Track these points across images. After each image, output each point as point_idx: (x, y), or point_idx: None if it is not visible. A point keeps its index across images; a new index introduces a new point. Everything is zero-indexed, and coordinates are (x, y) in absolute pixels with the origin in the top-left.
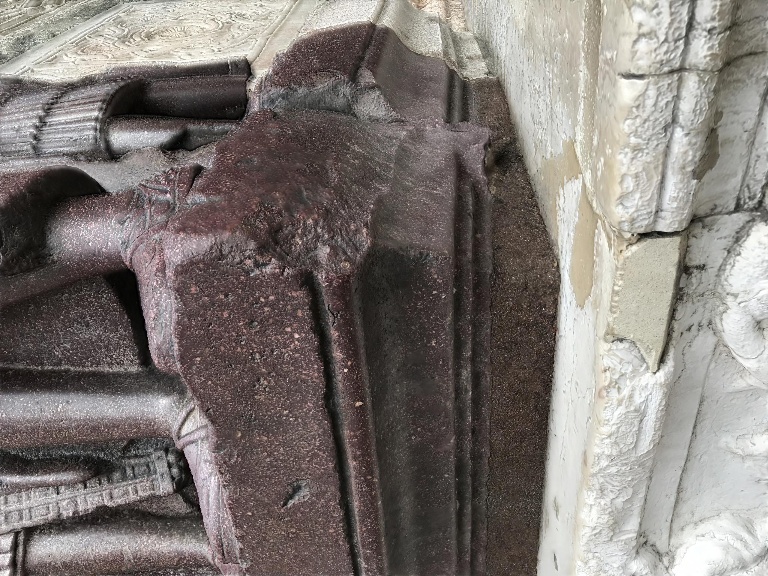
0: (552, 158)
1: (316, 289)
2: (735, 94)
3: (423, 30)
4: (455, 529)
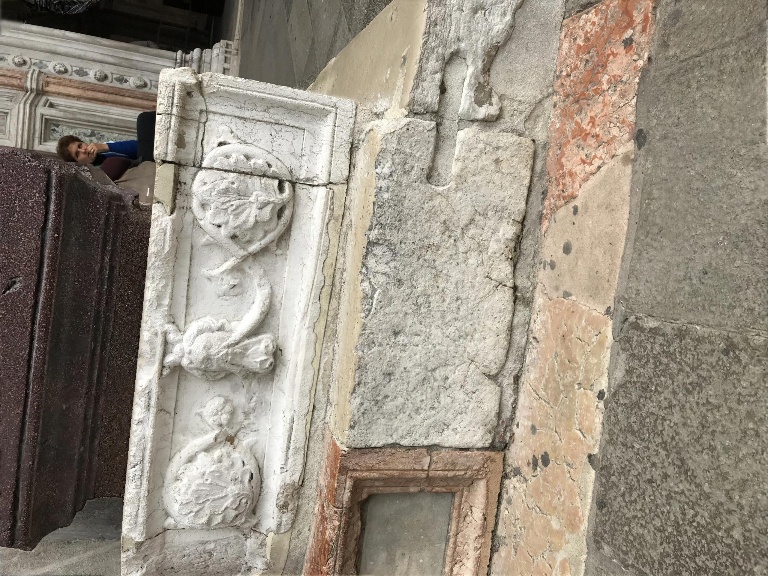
0: None
1: (51, 177)
2: (189, 129)
3: None
4: (89, 357)
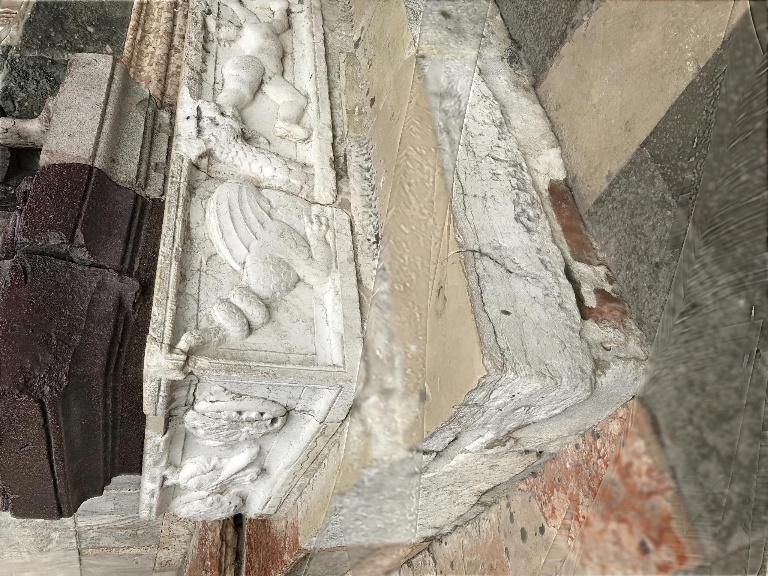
0: None
1: (43, 402)
2: (179, 391)
3: (130, 136)
4: (102, 445)
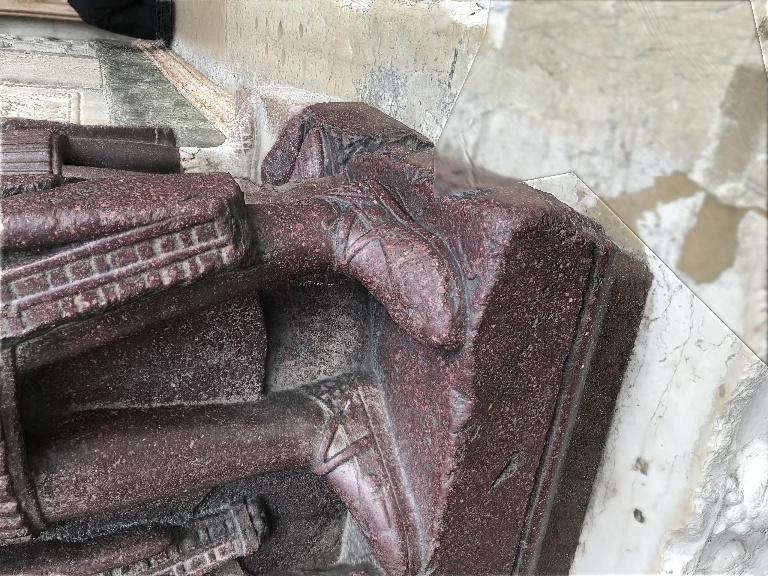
0: None
1: (593, 259)
2: None
3: None
4: (549, 514)
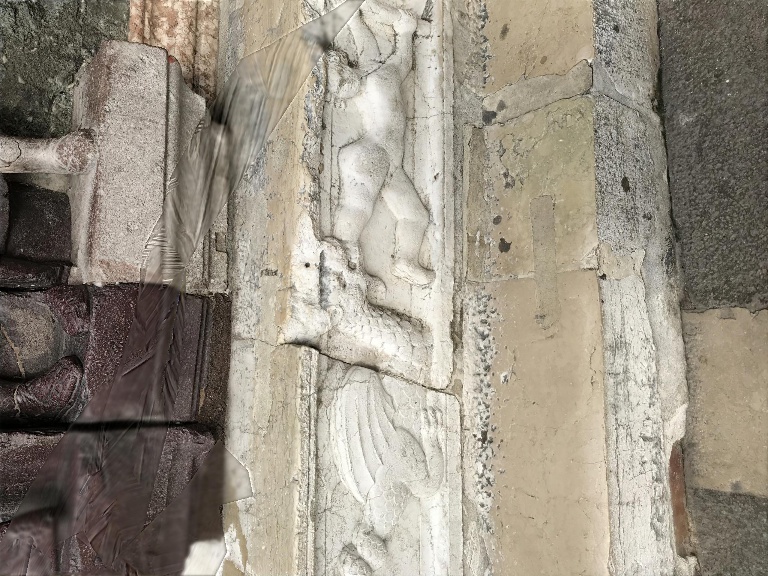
0: (238, 513)
1: None
2: None
3: None
4: None
